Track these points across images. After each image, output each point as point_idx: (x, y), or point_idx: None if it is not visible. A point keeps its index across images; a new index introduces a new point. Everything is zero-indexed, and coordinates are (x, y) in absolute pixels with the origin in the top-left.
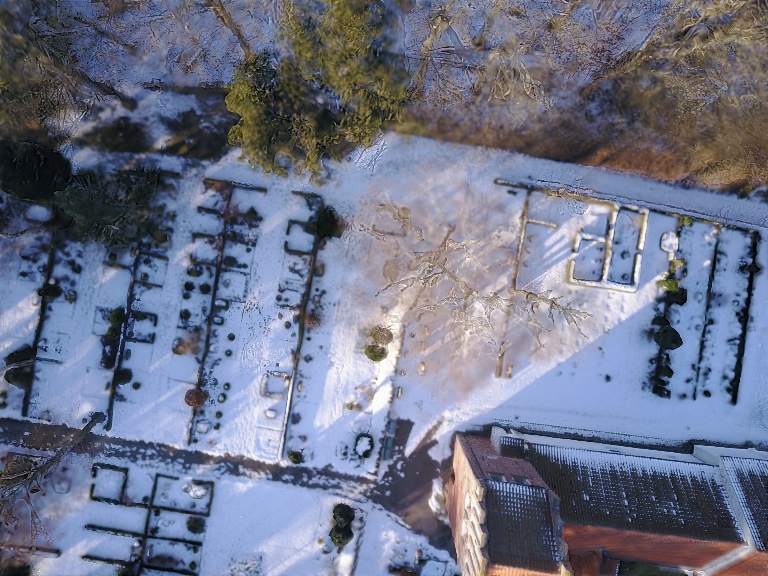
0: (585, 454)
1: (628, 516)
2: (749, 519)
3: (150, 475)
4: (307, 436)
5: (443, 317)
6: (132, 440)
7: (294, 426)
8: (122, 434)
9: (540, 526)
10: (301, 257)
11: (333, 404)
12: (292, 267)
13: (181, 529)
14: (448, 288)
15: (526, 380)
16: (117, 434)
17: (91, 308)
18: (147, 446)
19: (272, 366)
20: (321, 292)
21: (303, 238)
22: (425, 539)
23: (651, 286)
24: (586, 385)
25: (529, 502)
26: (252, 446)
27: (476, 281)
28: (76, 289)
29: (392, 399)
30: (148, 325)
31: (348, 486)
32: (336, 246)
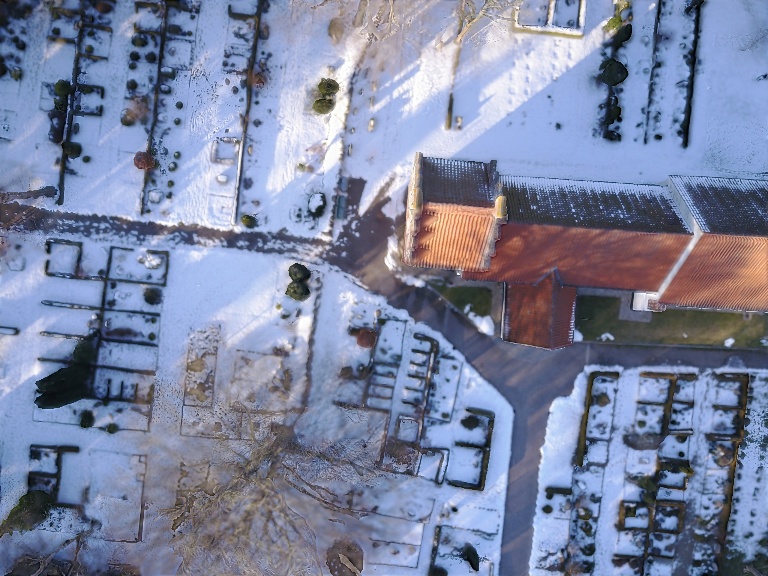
0: (533, 180)
1: (574, 218)
2: (695, 213)
3: (104, 248)
4: (260, 201)
5: (390, 73)
6: (85, 214)
7: (247, 192)
8: (74, 209)
9: (476, 183)
10: (245, 22)
11: (285, 167)
12: (237, 32)
13: (138, 301)
14: (394, 43)
15: (476, 132)
16: (69, 209)
17: (37, 84)
18: (100, 219)
19: (221, 132)
20: (267, 55)
21: (247, 2)
22: (383, 299)
23: (597, 32)
24: (536, 134)
25: (467, 170)
26: (205, 214)
27: (422, 35)
28: (21, 66)
29: (343, 156)
30: (95, 98)
31: (303, 249)
32: (280, 8)
